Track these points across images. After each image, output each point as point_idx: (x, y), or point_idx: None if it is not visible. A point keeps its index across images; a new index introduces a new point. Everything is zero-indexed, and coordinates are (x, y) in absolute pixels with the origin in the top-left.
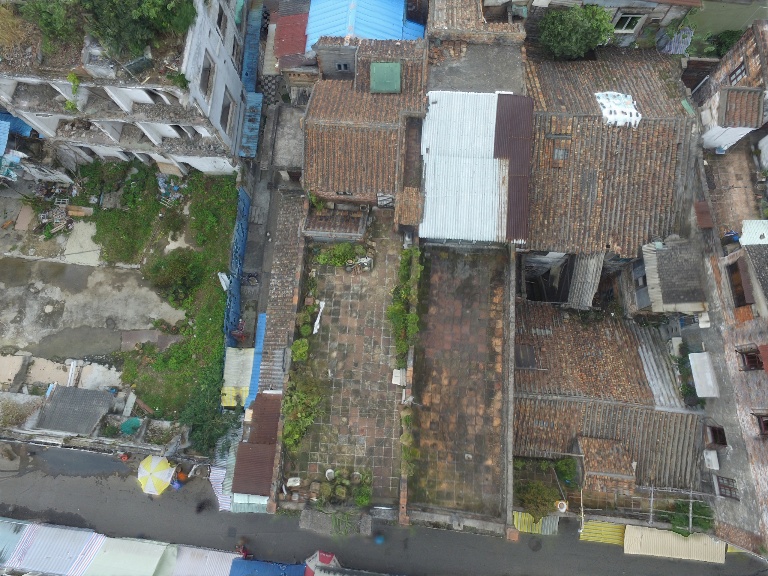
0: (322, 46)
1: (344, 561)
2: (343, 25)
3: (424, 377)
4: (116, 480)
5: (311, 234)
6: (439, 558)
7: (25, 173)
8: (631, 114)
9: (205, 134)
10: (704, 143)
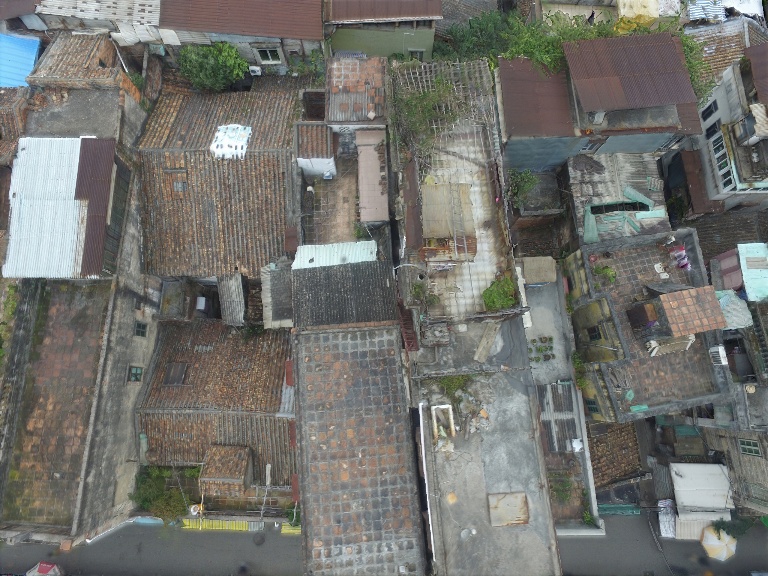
0: None
1: (81, 568)
2: None
3: (31, 404)
4: None
5: None
6: (169, 559)
7: None
8: (236, 147)
9: None
10: (308, 170)
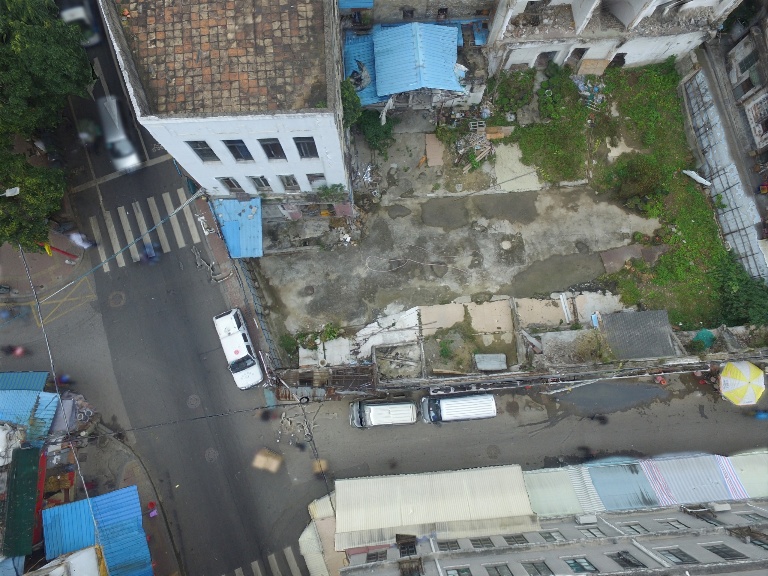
0: None
1: None
2: None
3: None
4: (660, 407)
5: None
6: None
7: (413, 102)
8: None
9: (692, 4)
10: None
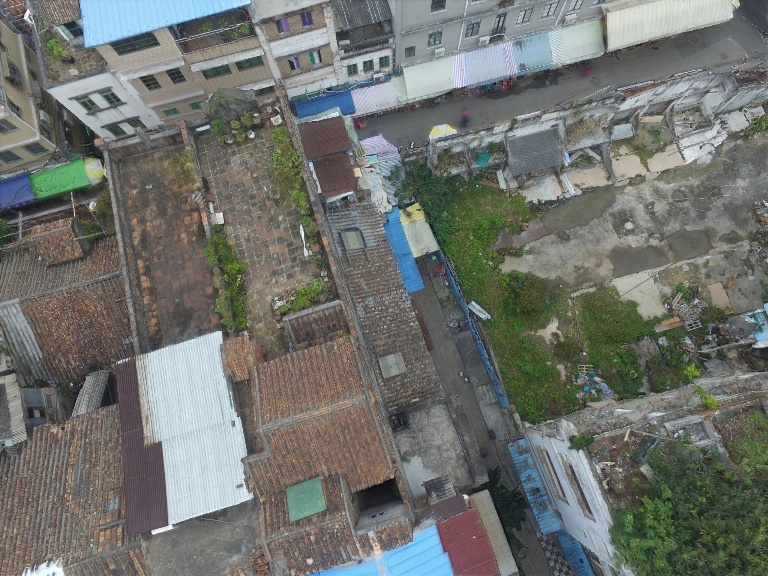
0: (400, 520)
1: None
2: (396, 575)
3: (202, 232)
4: None
5: (333, 303)
6: None
7: None
8: None
9: None
10: None
